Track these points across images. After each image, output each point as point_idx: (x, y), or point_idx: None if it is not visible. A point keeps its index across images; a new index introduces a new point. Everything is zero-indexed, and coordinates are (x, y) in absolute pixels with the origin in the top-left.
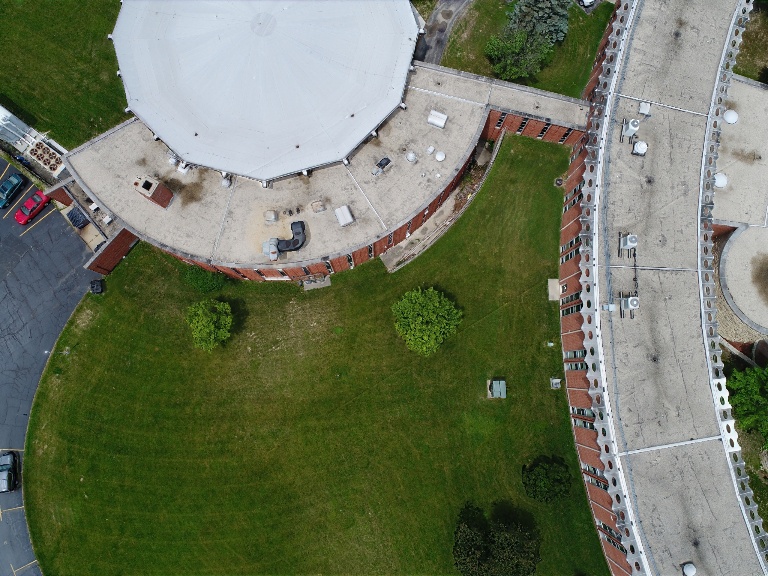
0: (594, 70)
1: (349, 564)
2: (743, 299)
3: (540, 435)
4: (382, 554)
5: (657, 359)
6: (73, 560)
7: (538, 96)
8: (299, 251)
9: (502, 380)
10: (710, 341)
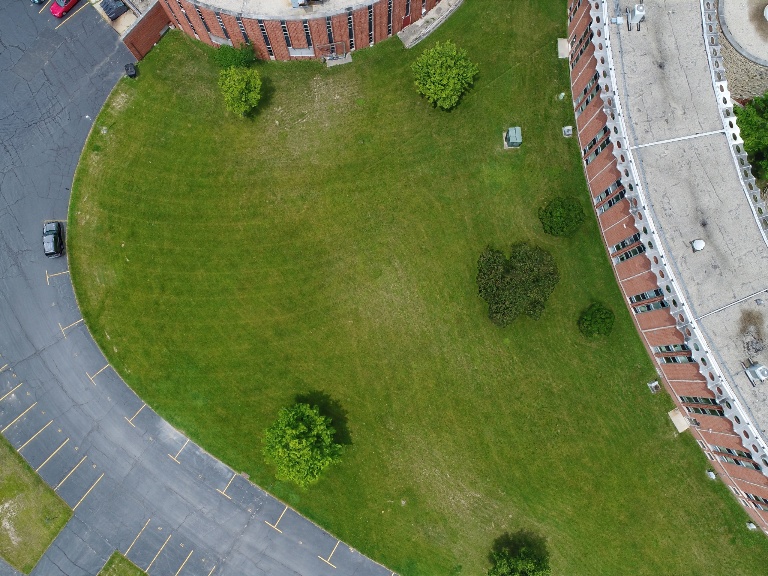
0: None
1: (378, 311)
2: (741, 35)
3: (554, 180)
4: (409, 300)
5: (663, 66)
6: (118, 317)
7: None
8: (324, 4)
9: (517, 126)
10: (712, 49)
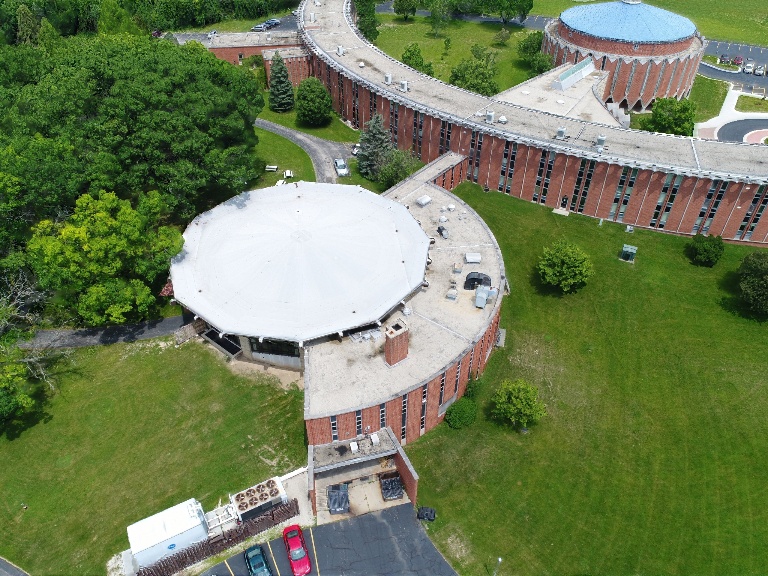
0: (423, 155)
1: None
2: None
3: (667, 248)
4: (762, 373)
5: (638, 147)
6: None
7: (432, 167)
8: None
9: None
10: None
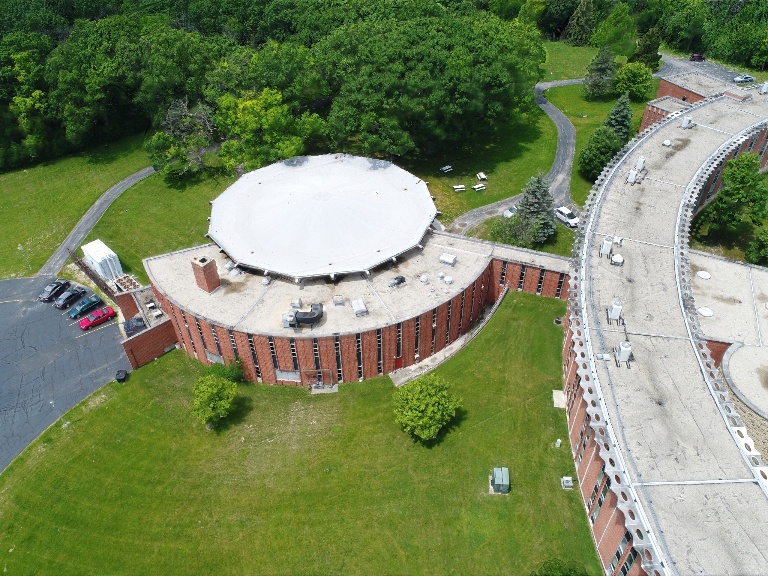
0: None
1: None
2: (757, 399)
3: (552, 539)
4: None
5: (662, 403)
6: None
7: (533, 255)
8: (314, 329)
9: (504, 467)
10: (718, 394)
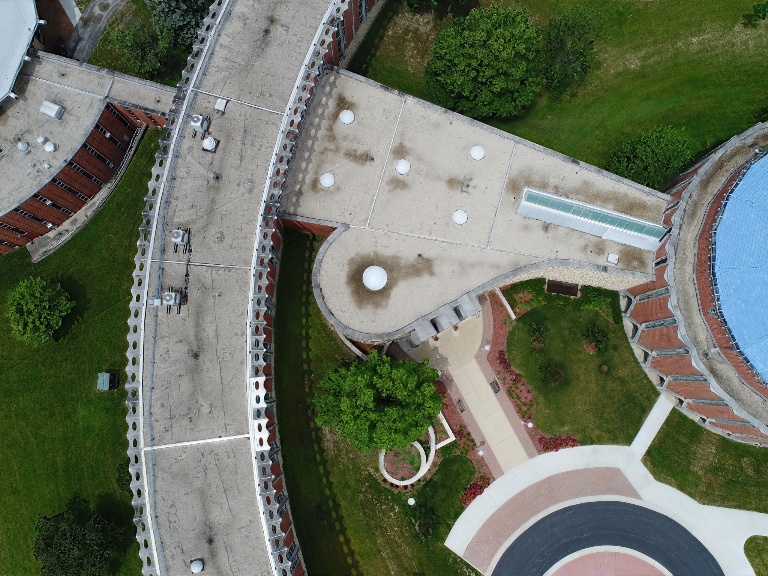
0: None
1: None
2: (335, 300)
3: None
4: None
5: (198, 355)
6: None
7: (160, 90)
8: None
9: None
10: (254, 339)
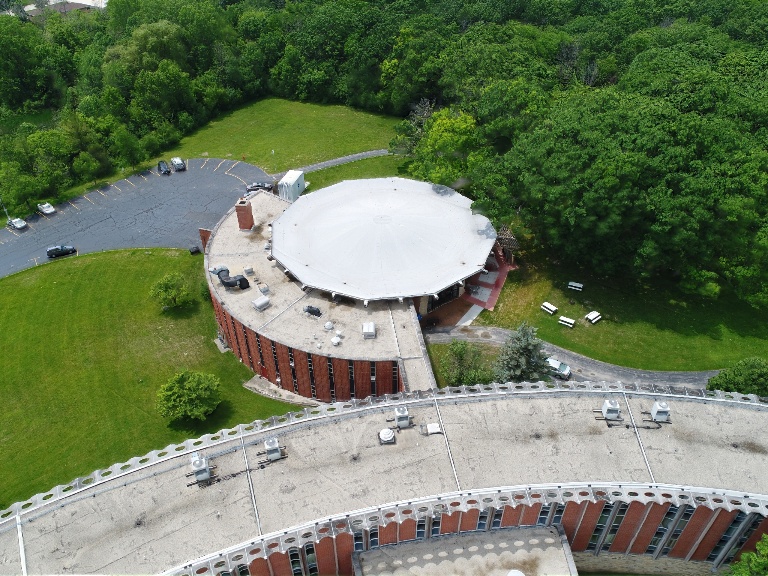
0: None
1: None
2: None
3: None
4: None
5: (140, 525)
6: None
7: None
8: (226, 291)
9: None
10: None
